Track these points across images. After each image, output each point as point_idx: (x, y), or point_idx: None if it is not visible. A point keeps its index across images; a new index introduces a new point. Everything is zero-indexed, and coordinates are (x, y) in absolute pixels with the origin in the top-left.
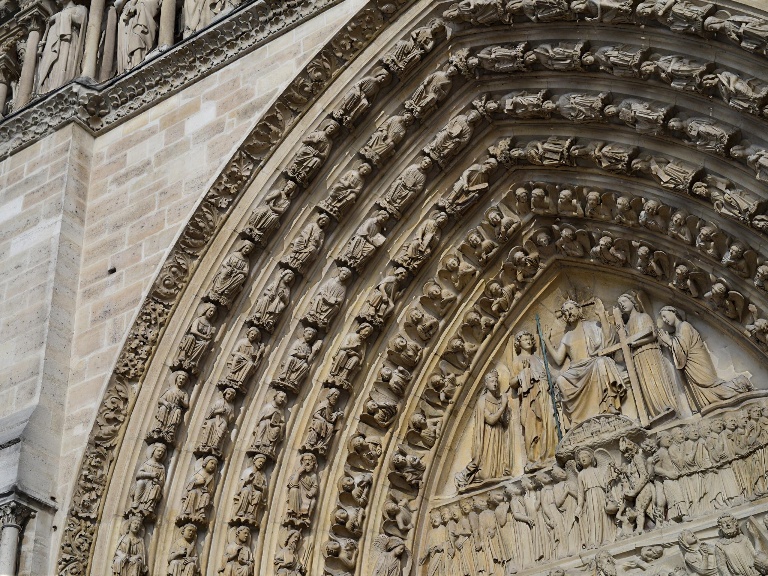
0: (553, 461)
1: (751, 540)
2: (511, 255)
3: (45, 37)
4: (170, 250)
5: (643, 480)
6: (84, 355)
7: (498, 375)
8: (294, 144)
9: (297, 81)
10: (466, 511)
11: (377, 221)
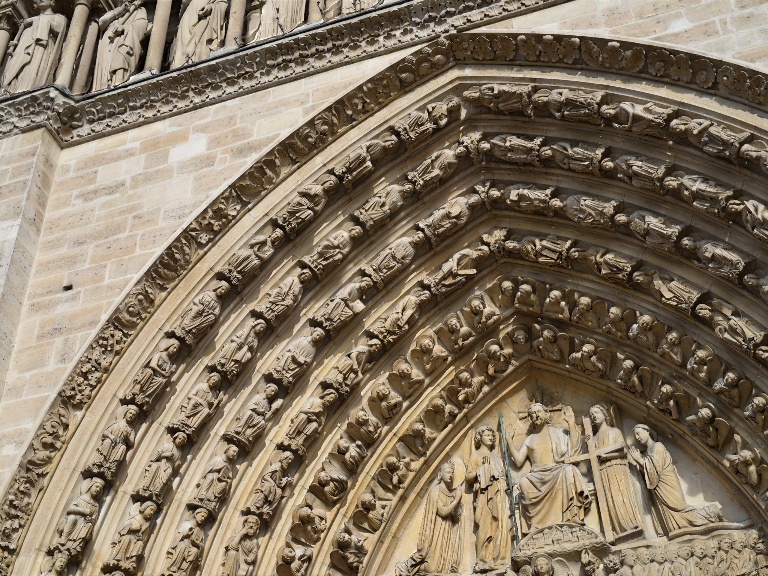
0: (506, 564)
1: None
2: (486, 347)
3: (18, 38)
4: (140, 276)
5: None
6: (25, 371)
7: (454, 467)
8: (288, 192)
9: (302, 130)
10: None
11: (360, 287)
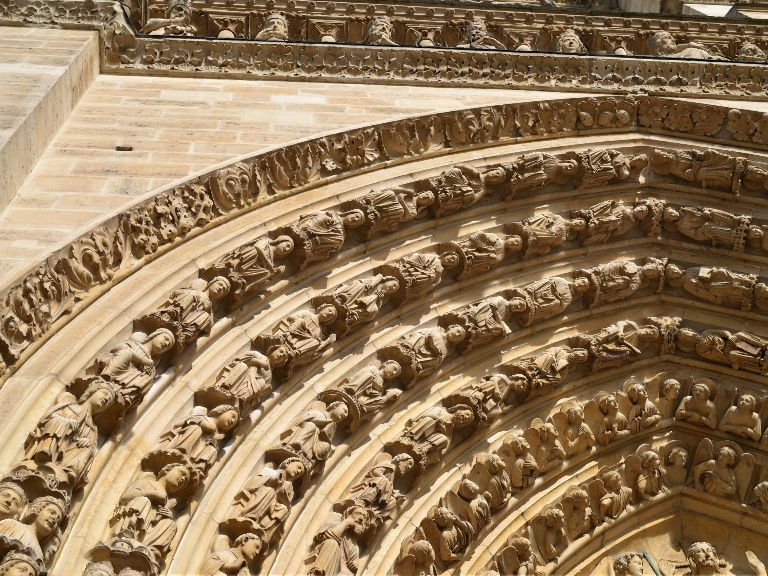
0: None
1: None
2: (640, 450)
3: None
4: (249, 156)
5: None
6: (53, 190)
7: None
8: (440, 165)
9: (466, 112)
10: None
11: (509, 304)
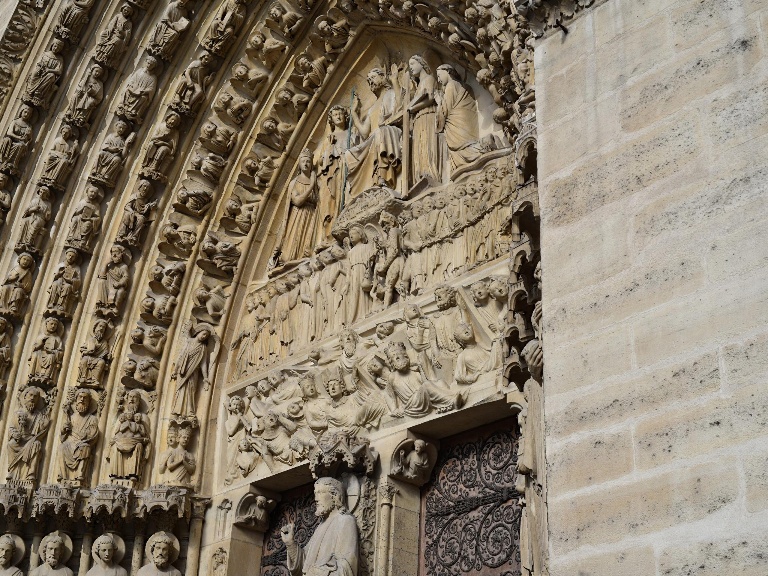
0: None
1: None
2: (316, 26)
3: None
4: None
5: (391, 254)
6: None
7: (313, 154)
8: None
9: None
10: (270, 295)
11: (178, 4)
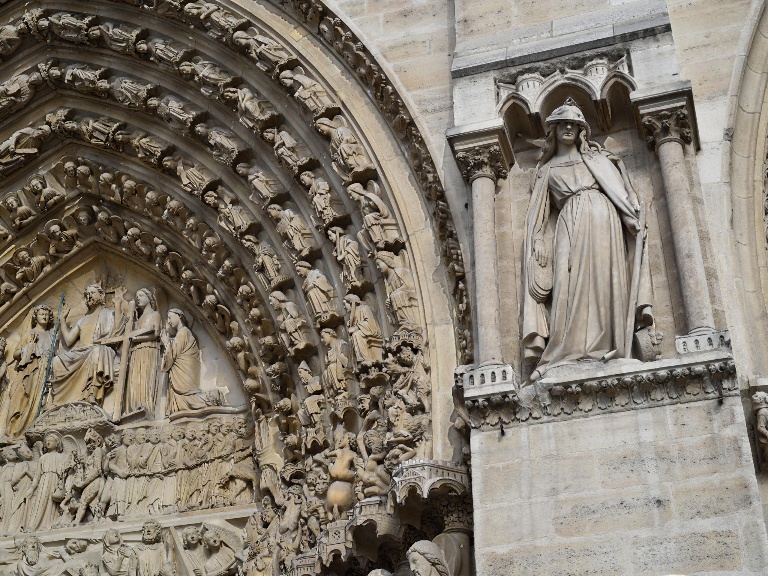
0: None
1: (167, 550)
2: (47, 227)
3: None
4: None
5: (94, 473)
6: None
7: (6, 344)
8: None
9: None
10: None
11: None
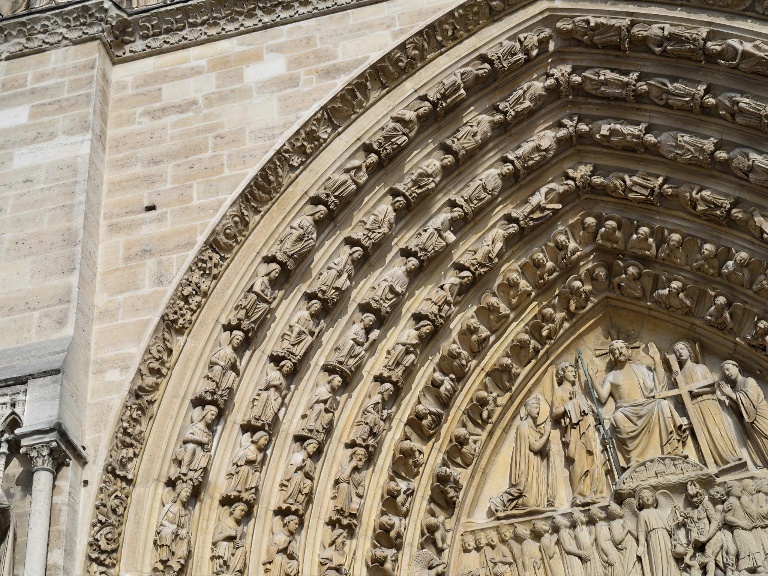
0: (606, 497)
1: None
2: (569, 283)
3: None
4: (235, 197)
5: (716, 526)
6: (116, 293)
7: None
8: (380, 117)
9: (394, 53)
10: (506, 538)
11: (451, 217)
